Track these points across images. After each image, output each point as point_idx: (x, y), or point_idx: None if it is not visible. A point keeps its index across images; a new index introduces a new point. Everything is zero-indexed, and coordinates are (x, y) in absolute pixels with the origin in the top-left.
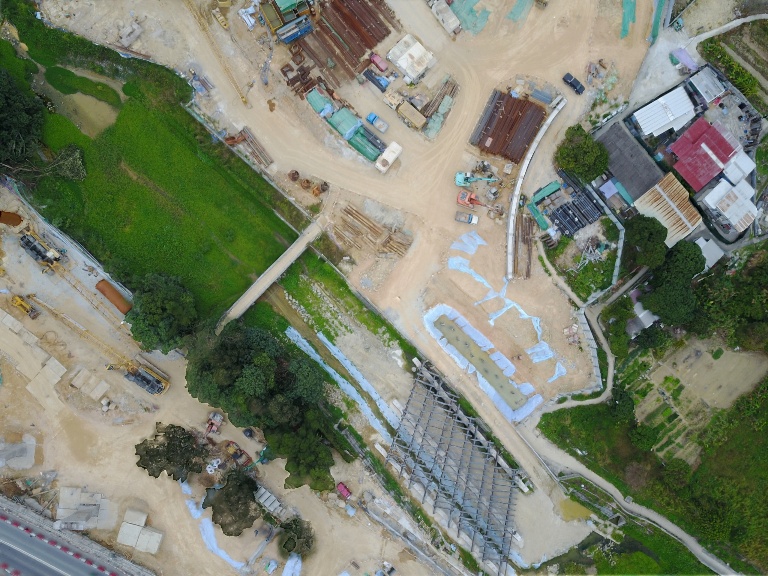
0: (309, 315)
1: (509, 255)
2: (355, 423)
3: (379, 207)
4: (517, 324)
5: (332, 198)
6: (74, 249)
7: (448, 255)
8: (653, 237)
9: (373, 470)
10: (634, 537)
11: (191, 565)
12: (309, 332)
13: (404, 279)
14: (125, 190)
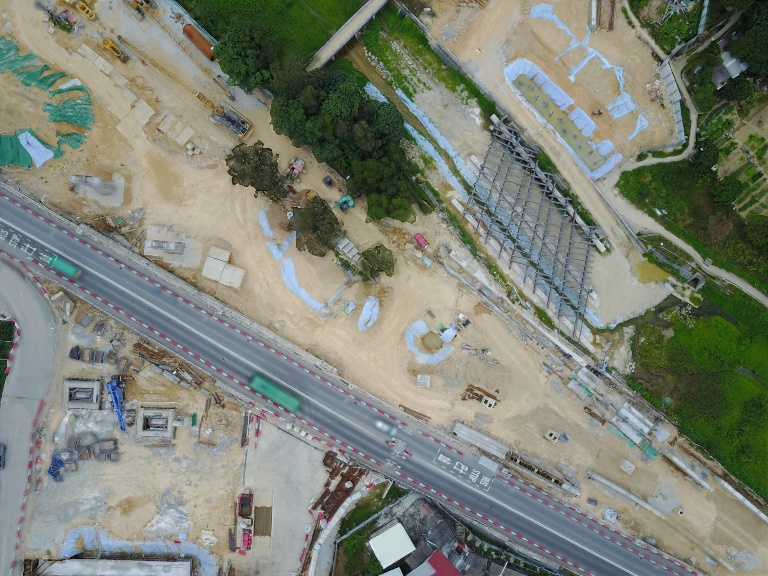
0: (388, 72)
1: (593, 0)
2: (432, 179)
3: None
4: (599, 76)
5: None
6: None
7: (530, 3)
8: None
9: (450, 223)
10: (713, 300)
11: (272, 304)
12: (388, 89)
13: (485, 30)
14: None
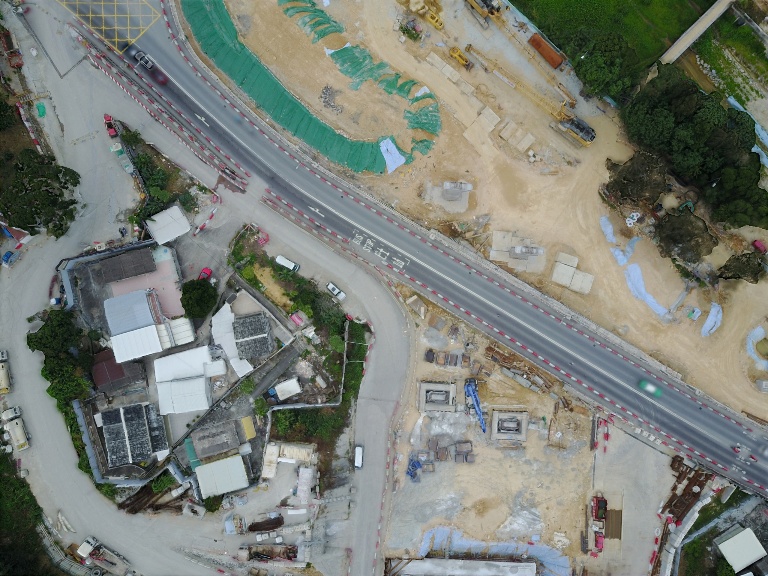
0: (720, 80)
1: None
2: (764, 187)
3: None
4: None
5: None
6: (506, 5)
7: None
8: None
9: None
10: None
11: (616, 310)
12: None
13: None
14: None
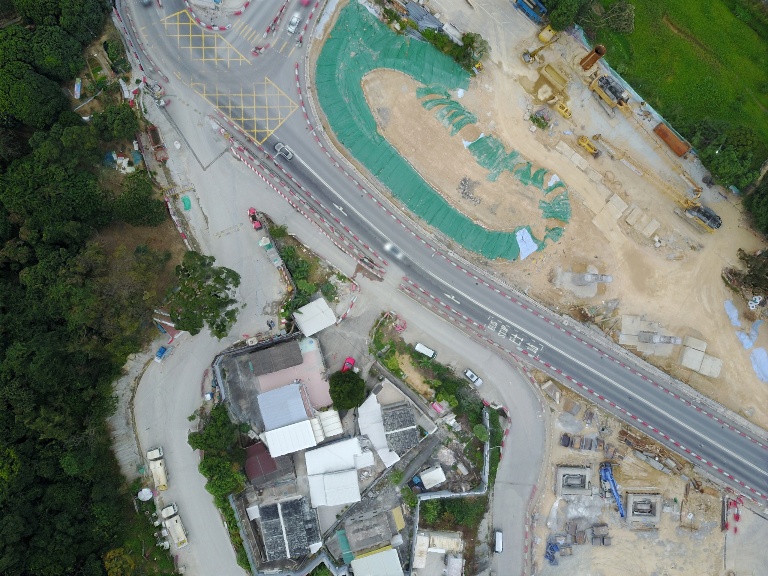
0: None
1: None
2: None
3: None
4: None
5: None
6: (631, 95)
7: None
8: None
9: None
10: None
11: (742, 392)
12: None
13: None
14: (670, 42)
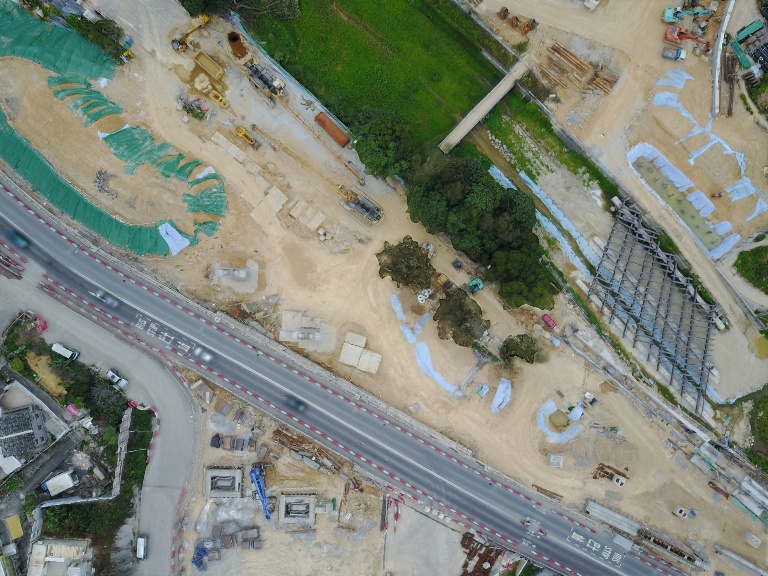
0: (511, 155)
1: (716, 89)
2: (556, 260)
3: (586, 45)
4: (720, 161)
5: (539, 37)
6: (293, 83)
7: (654, 91)
8: None
9: (576, 303)
10: None
11: (407, 388)
12: (511, 172)
13: (609, 116)
14: (338, 29)
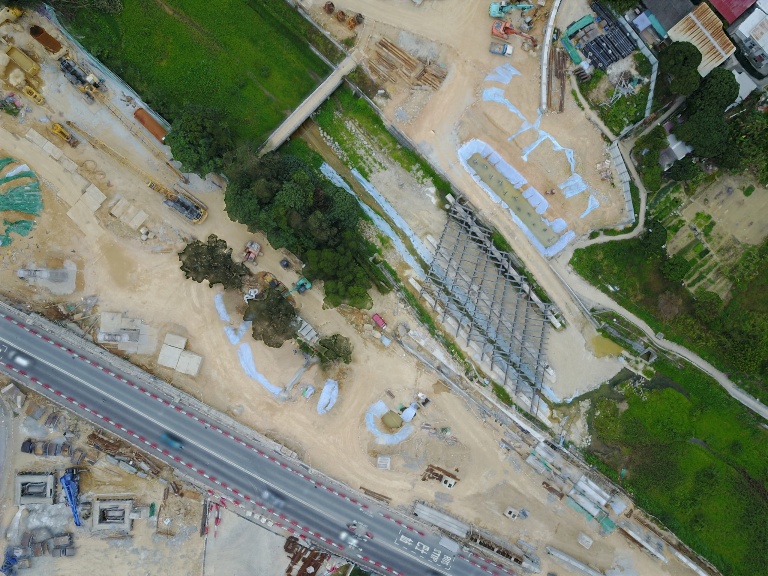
0: (344, 152)
1: (543, 85)
2: (389, 259)
3: (414, 40)
4: (550, 157)
5: (367, 32)
6: (112, 79)
7: (482, 87)
8: (688, 62)
9: (408, 303)
10: (665, 373)
11: (230, 390)
12: (344, 169)
13: (438, 112)
14: (162, 24)
